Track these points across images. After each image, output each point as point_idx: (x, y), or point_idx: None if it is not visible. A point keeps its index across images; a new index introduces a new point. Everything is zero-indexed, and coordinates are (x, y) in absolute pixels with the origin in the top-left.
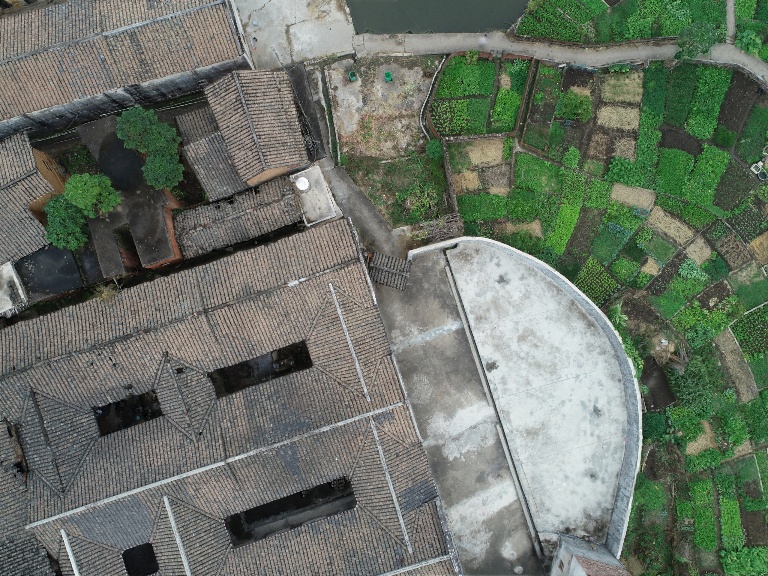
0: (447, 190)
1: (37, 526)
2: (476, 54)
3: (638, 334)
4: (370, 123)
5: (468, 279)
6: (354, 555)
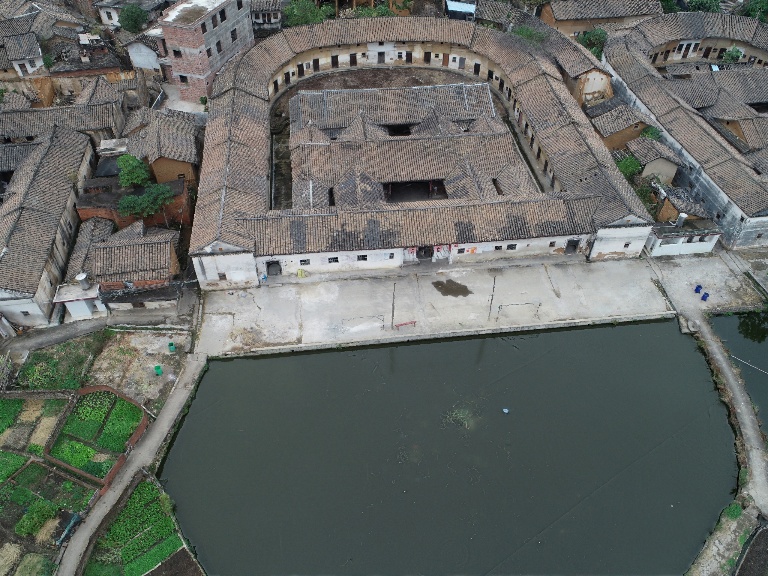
0: None
1: None
2: None
3: None
4: (130, 355)
5: None
6: None
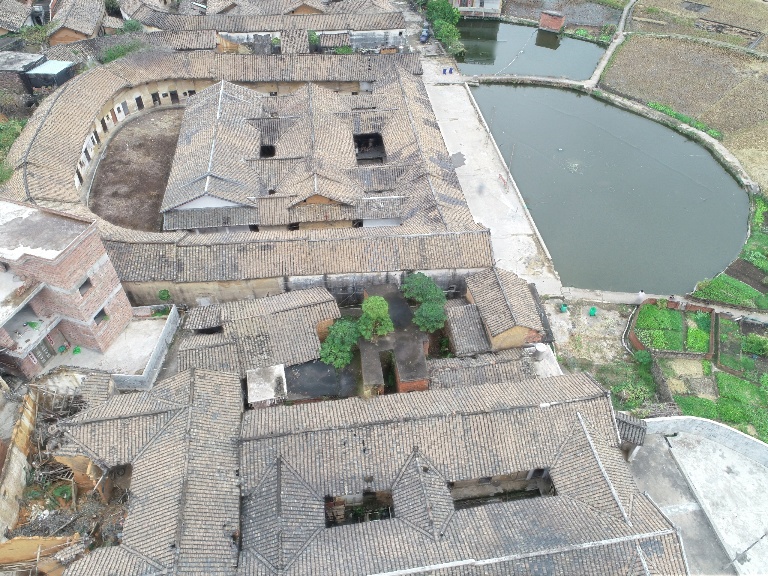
0: (657, 391)
1: None
2: (666, 301)
3: None
4: (580, 339)
5: (695, 465)
6: None
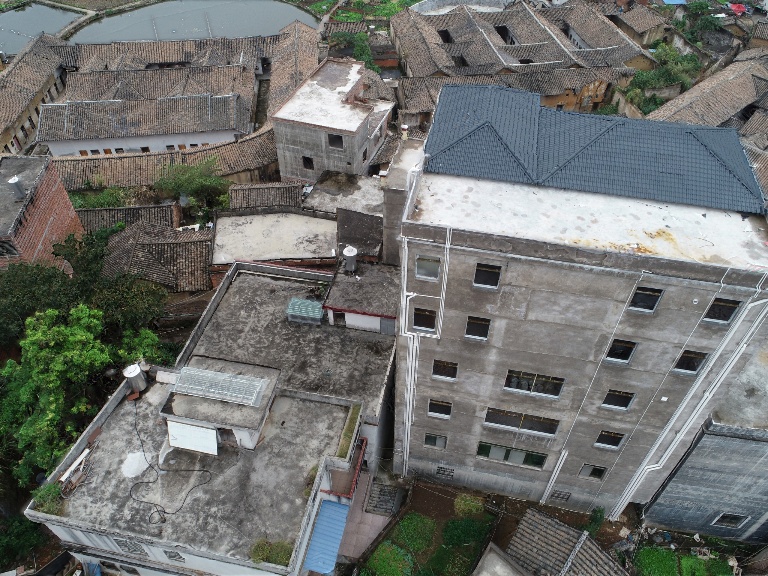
0: None
1: (507, 65)
2: None
3: None
4: None
5: None
6: None
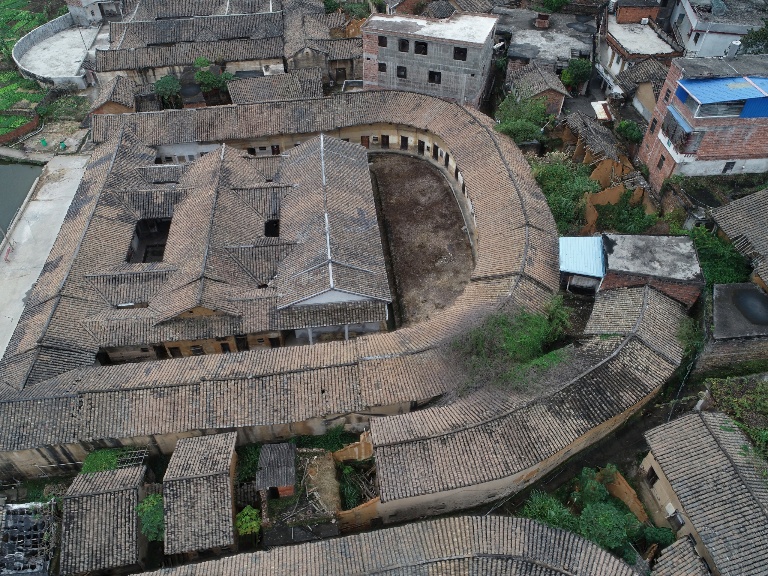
0: None
1: None
2: None
3: (5, 62)
4: None
5: None
6: (162, 4)
